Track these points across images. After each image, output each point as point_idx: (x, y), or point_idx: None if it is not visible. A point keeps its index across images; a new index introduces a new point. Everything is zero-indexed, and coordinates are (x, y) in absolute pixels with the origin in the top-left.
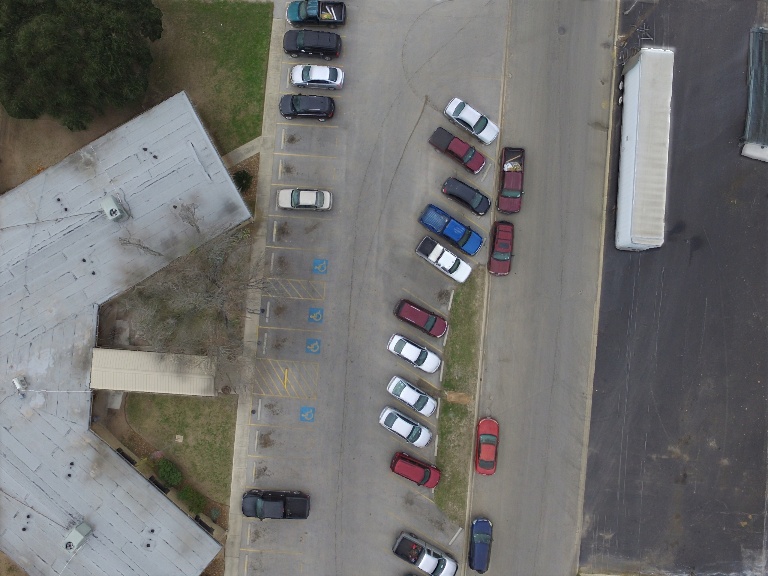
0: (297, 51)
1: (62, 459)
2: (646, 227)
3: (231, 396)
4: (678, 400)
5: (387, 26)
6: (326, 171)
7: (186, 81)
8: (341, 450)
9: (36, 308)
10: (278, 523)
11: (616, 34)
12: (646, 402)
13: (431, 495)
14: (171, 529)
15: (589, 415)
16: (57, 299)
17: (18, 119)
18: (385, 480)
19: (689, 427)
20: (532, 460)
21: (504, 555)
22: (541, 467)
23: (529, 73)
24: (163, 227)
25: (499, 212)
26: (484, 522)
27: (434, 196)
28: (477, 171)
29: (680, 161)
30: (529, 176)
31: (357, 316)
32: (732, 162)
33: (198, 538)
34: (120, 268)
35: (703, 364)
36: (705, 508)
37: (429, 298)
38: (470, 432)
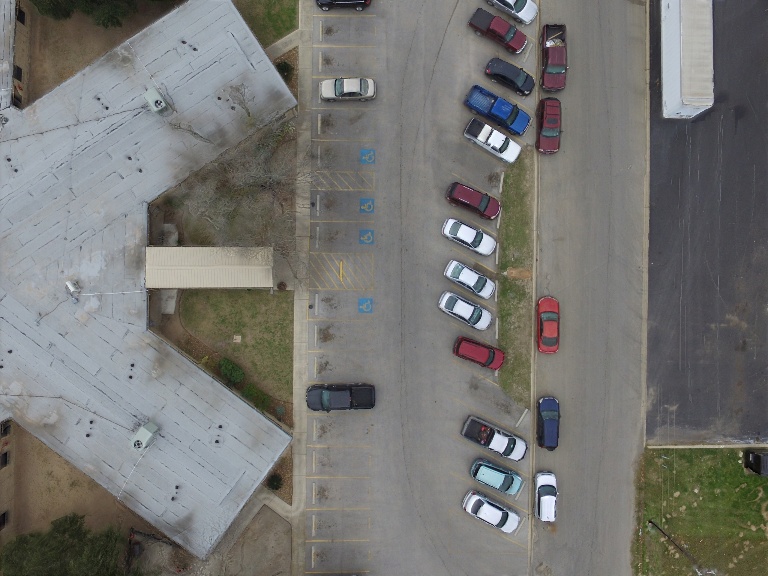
0: None
1: (122, 362)
2: (696, 87)
3: (287, 293)
4: (733, 268)
5: None
6: (367, 61)
7: None
8: (402, 339)
9: (83, 211)
10: (343, 417)
11: None
12: (702, 272)
13: (495, 378)
14: (239, 424)
15: (646, 288)
16: (105, 200)
17: (47, 28)
18: (448, 366)
19: (745, 294)
20: (593, 336)
21: (571, 433)
22: (602, 343)
23: None
24: (209, 120)
25: (544, 90)
26: (550, 400)
27: (477, 79)
28: (520, 50)
29: (719, 30)
30: (571, 54)
31: (409, 204)
32: None
33: (267, 431)
34: (167, 164)
35: (755, 230)
36: (766, 373)
37: (479, 182)
38: (529, 313)
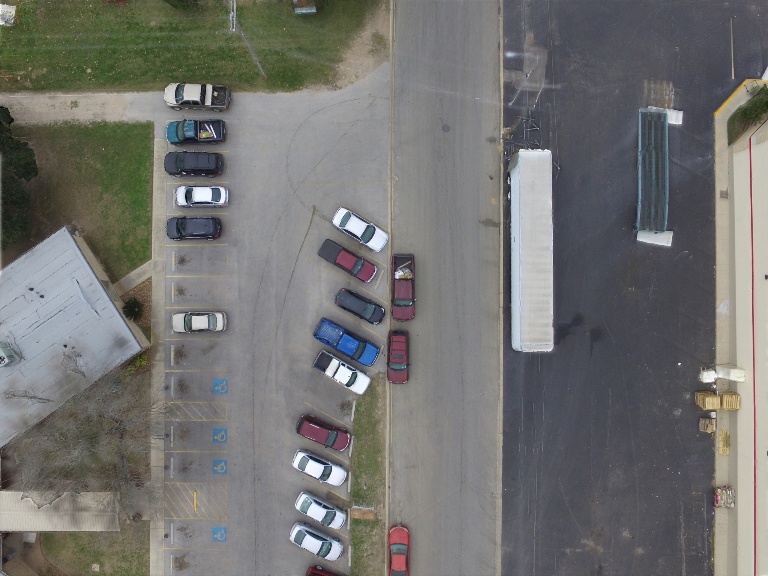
0: (179, 173)
1: None
2: (535, 333)
3: (143, 522)
4: (588, 492)
5: (269, 137)
6: (219, 290)
7: (73, 209)
8: (256, 567)
9: None
10: None
11: (501, 127)
12: (556, 497)
13: None
14: None
15: (500, 514)
16: None
17: None
18: None
19: (601, 519)
20: (446, 563)
21: None
22: (455, 569)
23: (416, 174)
24: (56, 367)
25: (394, 319)
26: None
27: (329, 307)
28: (368, 280)
29: (574, 252)
30: (423, 279)
31: (261, 434)
32: (627, 249)
33: None
34: (17, 411)
35: (611, 455)
36: None
37: (331, 410)
38: (382, 540)
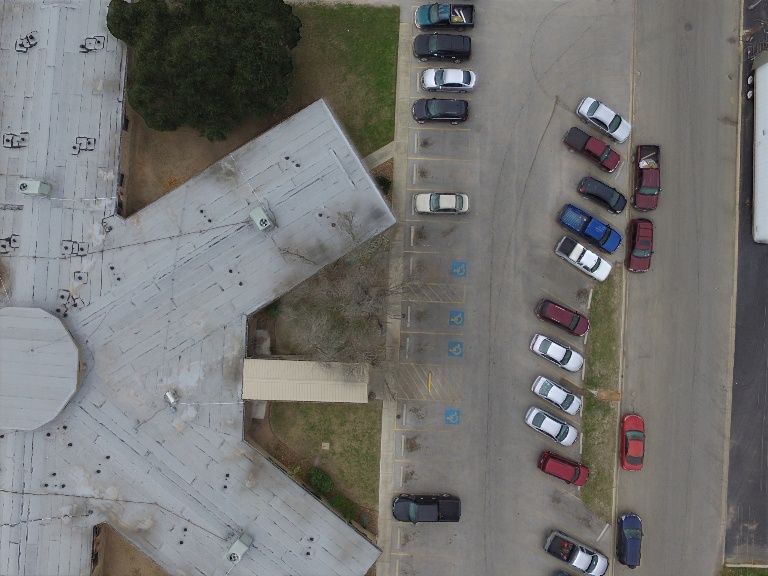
0: (429, 55)
1: (217, 471)
2: None
3: (375, 402)
4: None
5: (514, 27)
6: (460, 174)
7: (315, 88)
8: (487, 451)
9: (183, 321)
10: (427, 526)
11: (742, 29)
12: None
13: (577, 493)
14: (330, 536)
15: (730, 408)
16: (205, 311)
17: (146, 131)
18: (532, 480)
19: None
20: (676, 454)
21: (651, 549)
22: (685, 461)
23: (657, 70)
24: (309, 236)
25: (635, 210)
26: (633, 517)
27: (569, 196)
28: (612, 169)
29: None
30: (662, 173)
31: (498, 318)
32: None
33: (357, 544)
34: (267, 278)
35: None
36: None
37: (568, 297)
38: (614, 429)
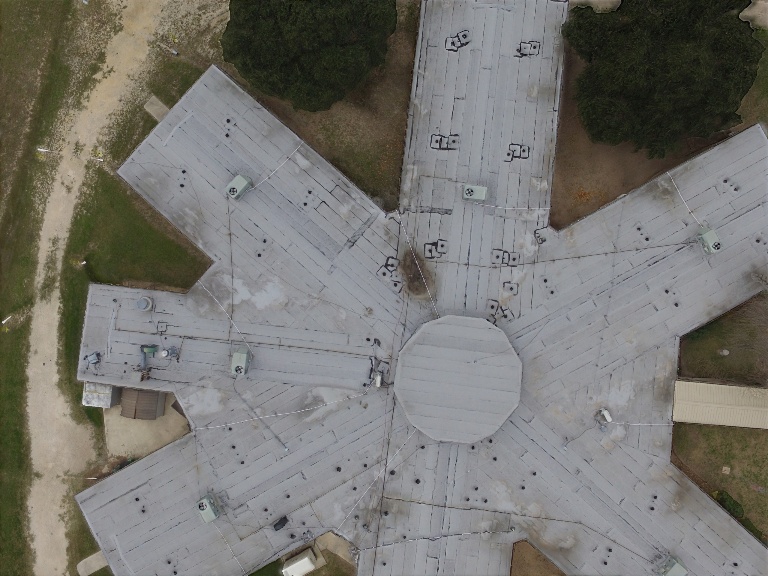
0: None
1: (643, 492)
2: None
3: None
4: None
5: None
6: None
7: None
8: None
9: (615, 339)
10: None
11: None
12: None
13: None
14: (752, 562)
15: None
16: (638, 330)
17: None
18: None
19: None
20: None
21: None
22: None
23: None
24: (744, 261)
25: None
26: None
27: None
28: None
29: None
30: None
31: None
32: None
33: None
34: (702, 301)
35: None
36: None
37: None
38: None
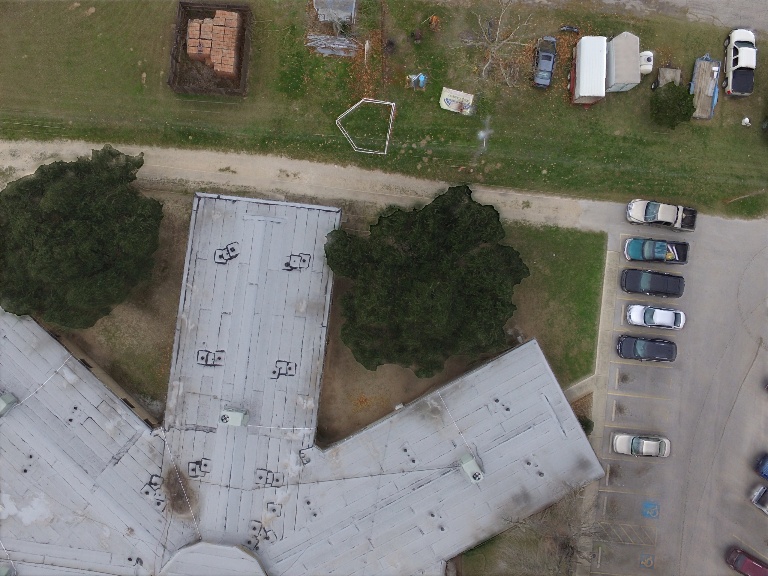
0: (640, 292)
1: None
2: None
3: None
4: None
5: (723, 263)
6: (660, 413)
7: (517, 313)
8: None
9: (380, 562)
10: None
11: None
12: None
13: None
14: None
15: None
16: (403, 554)
17: (338, 345)
18: None
19: None
20: None
21: None
22: None
23: None
24: (515, 483)
25: None
26: None
27: (767, 442)
28: None
29: None
30: None
31: (688, 563)
32: None
33: None
34: (470, 524)
35: None
36: None
37: (759, 545)
38: None
